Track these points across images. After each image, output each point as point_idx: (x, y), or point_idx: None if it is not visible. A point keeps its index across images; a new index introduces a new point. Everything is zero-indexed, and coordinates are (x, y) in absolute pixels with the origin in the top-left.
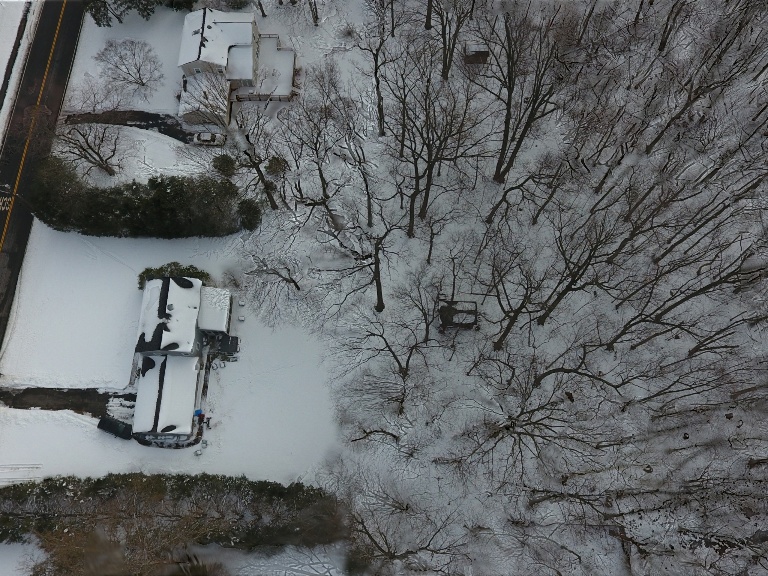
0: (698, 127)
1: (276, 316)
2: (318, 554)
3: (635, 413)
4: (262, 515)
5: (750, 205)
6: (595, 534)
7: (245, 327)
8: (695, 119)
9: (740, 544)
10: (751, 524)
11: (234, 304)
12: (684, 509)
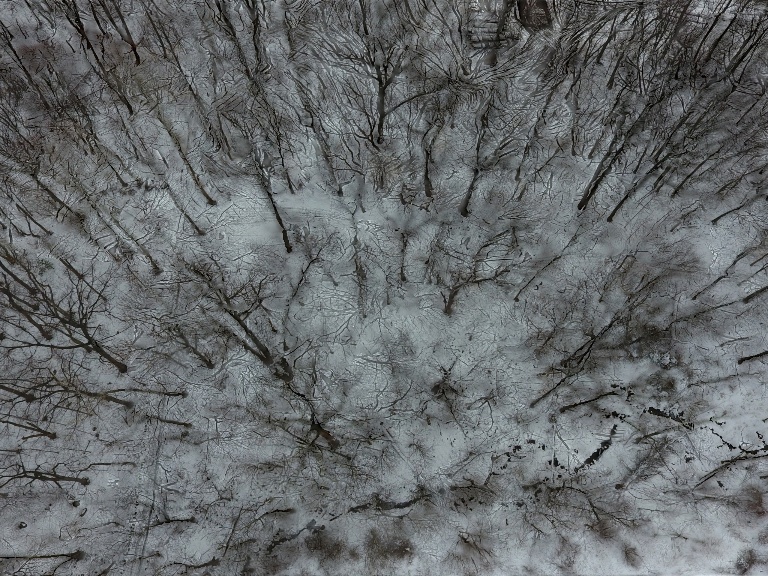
0: (143, 195)
1: None
2: None
3: None
4: None
5: (168, 278)
6: None
7: None
8: (142, 187)
9: None
10: None
11: None
12: None
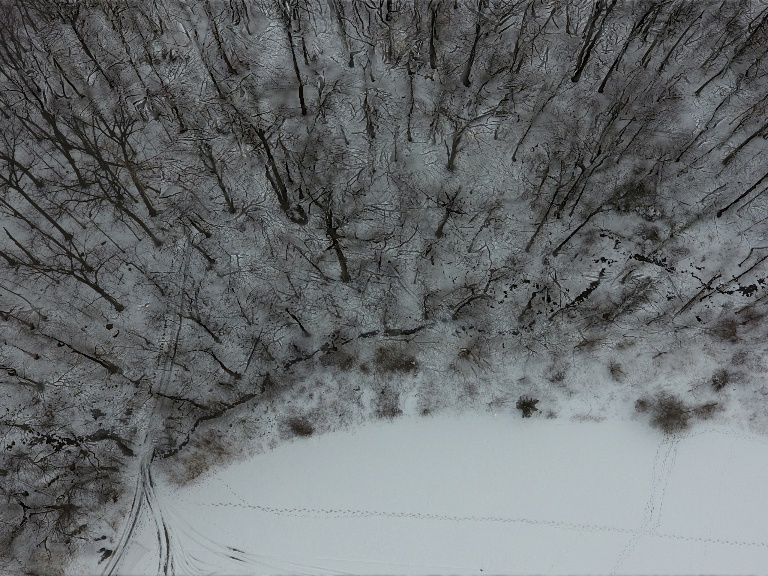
0: (168, 64)
1: None
2: None
3: (14, 322)
4: None
5: (192, 136)
6: None
7: None
8: (167, 57)
9: (78, 441)
10: (96, 424)
11: None
12: (33, 409)
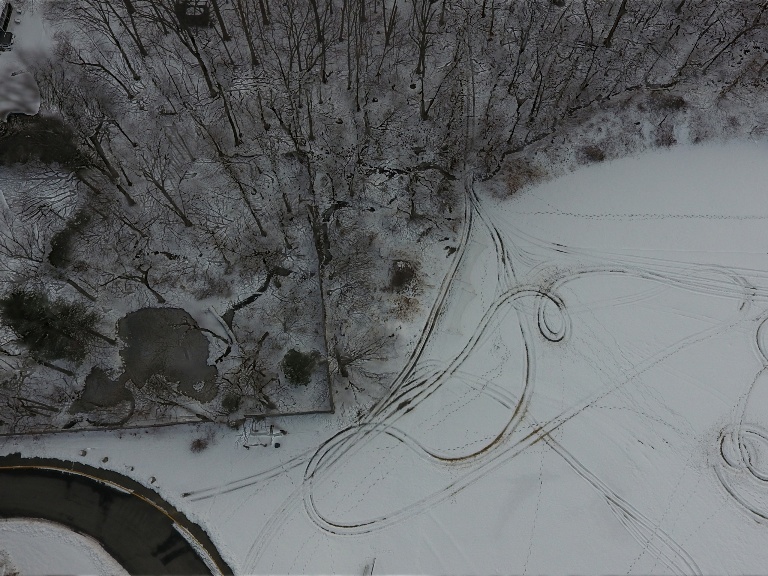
0: None
1: (33, 2)
2: (53, 168)
3: (334, 83)
4: (5, 134)
5: None
6: (287, 163)
7: (20, 27)
8: None
9: (407, 171)
10: (418, 158)
11: (13, 12)
12: None
